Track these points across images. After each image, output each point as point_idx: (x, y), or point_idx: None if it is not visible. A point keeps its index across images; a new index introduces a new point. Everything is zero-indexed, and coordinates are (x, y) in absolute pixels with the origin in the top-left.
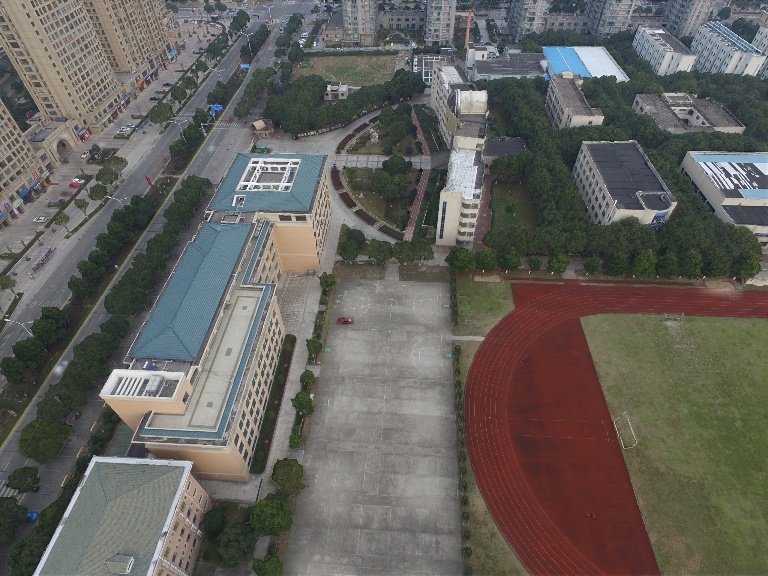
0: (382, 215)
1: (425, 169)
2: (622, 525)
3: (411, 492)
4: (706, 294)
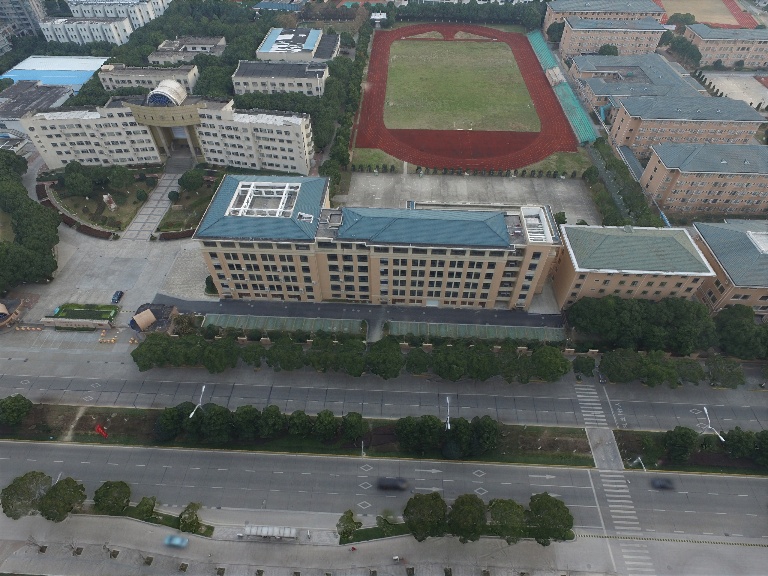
0: None
1: None
2: (510, 136)
3: (515, 192)
4: (369, 91)
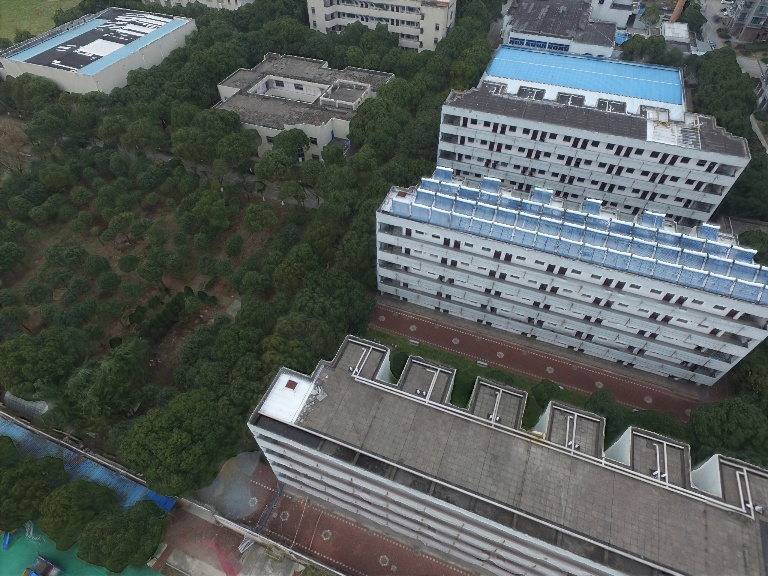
0: None
1: None
2: None
3: None
4: None
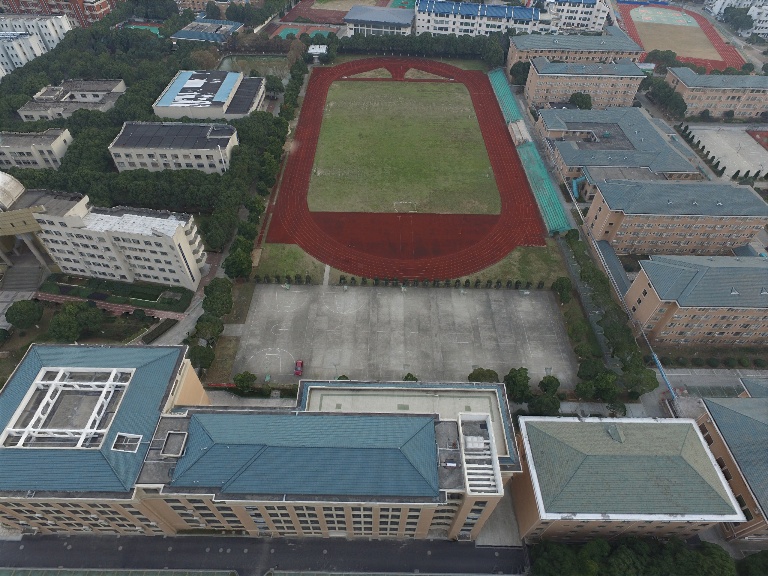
0: (116, 343)
1: (32, 297)
2: (463, 222)
3: (466, 314)
4: (295, 153)
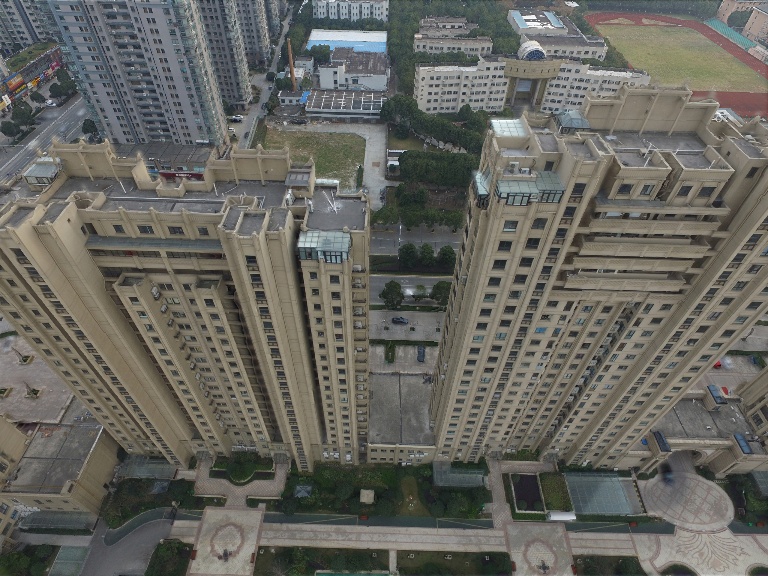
0: None
1: None
2: (764, 96)
3: None
4: None
